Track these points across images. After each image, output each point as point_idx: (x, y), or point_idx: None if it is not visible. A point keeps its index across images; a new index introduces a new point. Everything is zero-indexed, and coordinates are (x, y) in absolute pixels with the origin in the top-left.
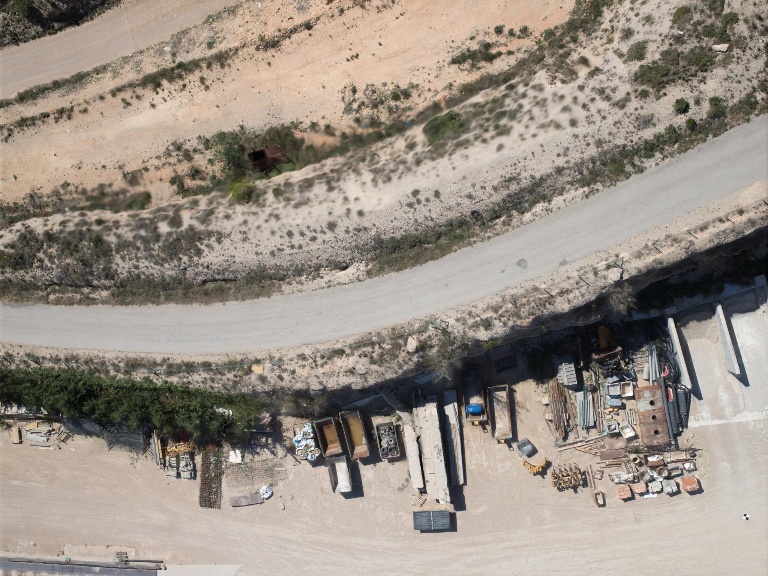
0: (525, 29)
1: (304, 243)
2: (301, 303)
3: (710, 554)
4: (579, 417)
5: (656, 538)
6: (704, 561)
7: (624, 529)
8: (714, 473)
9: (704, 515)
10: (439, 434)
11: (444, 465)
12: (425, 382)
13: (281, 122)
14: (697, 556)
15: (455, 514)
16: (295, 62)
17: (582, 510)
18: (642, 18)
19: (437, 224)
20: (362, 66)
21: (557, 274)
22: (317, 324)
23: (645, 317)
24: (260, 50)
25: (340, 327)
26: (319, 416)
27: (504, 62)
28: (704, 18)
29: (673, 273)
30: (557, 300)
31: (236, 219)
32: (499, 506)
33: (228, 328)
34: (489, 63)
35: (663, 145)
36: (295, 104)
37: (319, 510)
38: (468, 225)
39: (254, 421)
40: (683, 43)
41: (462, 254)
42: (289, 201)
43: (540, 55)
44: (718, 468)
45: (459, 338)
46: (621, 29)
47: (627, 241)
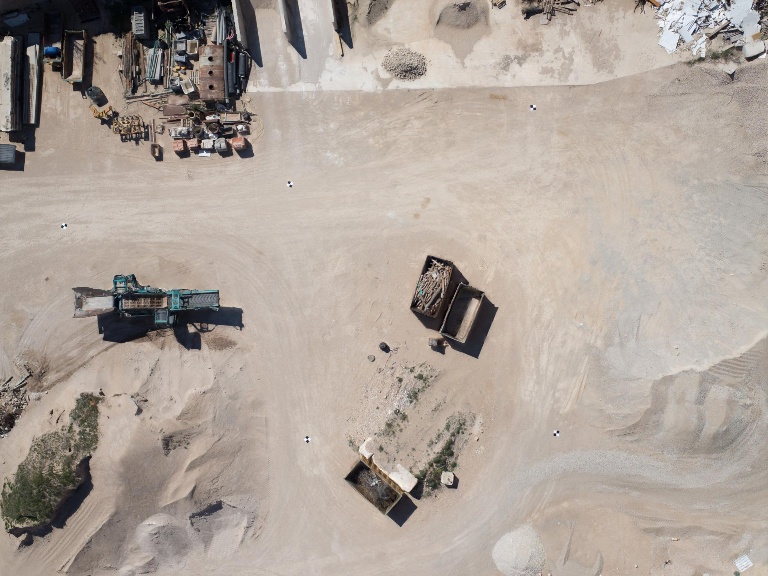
0: None
1: None
2: None
3: (252, 217)
4: (147, 69)
5: (205, 196)
6: (246, 223)
7: (176, 184)
8: (265, 138)
9: (251, 178)
10: (10, 63)
11: (10, 93)
12: (15, 26)
13: None
14: (240, 218)
15: (24, 154)
16: None
17: (141, 162)
18: None
19: None
20: None
21: None
22: None
23: None
24: None
25: None
26: None
27: None
28: None
29: None
30: None
31: None
32: (65, 150)
33: None
34: None
35: None
36: None
37: None
38: None
39: None
40: None
41: None
42: None
43: None
44: (269, 134)
45: None
46: None
47: None
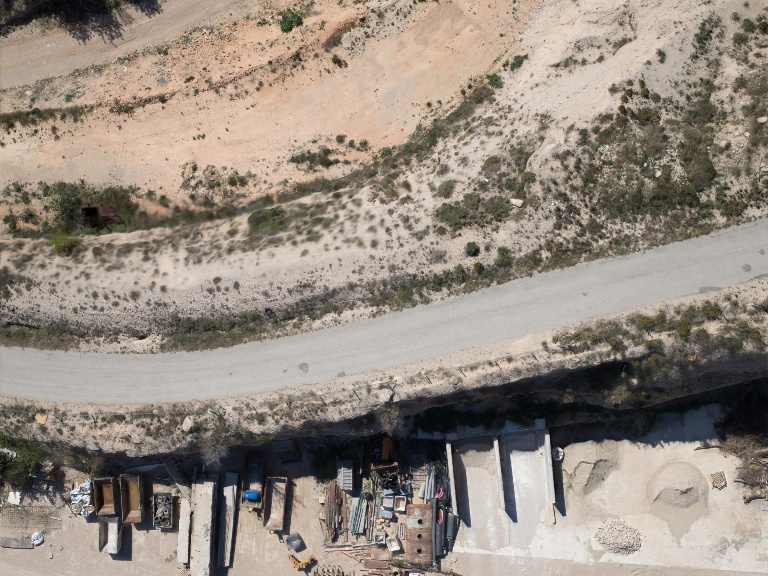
0: (365, 143)
1: (106, 306)
2: (94, 363)
3: None
4: (350, 522)
5: None
6: None
7: None
8: None
9: None
10: (210, 514)
11: (209, 545)
12: None
13: (120, 184)
14: None
15: None
16: (144, 130)
17: None
18: (460, 158)
19: (232, 314)
20: (207, 147)
21: (334, 384)
22: (105, 386)
23: (429, 437)
24: (114, 112)
25: (126, 394)
26: (102, 474)
27: (340, 170)
28: (510, 171)
29: (449, 403)
30: (329, 409)
31: (50, 270)
32: None
33: (22, 373)
34: (326, 168)
35: (451, 282)
36: (137, 170)
37: (85, 566)
38: (261, 320)
39: (35, 467)
40: (486, 190)
41: (251, 347)
42: (104, 263)
43: (373, 170)
44: None
45: (234, 427)
46: (440, 164)
47: (403, 366)
